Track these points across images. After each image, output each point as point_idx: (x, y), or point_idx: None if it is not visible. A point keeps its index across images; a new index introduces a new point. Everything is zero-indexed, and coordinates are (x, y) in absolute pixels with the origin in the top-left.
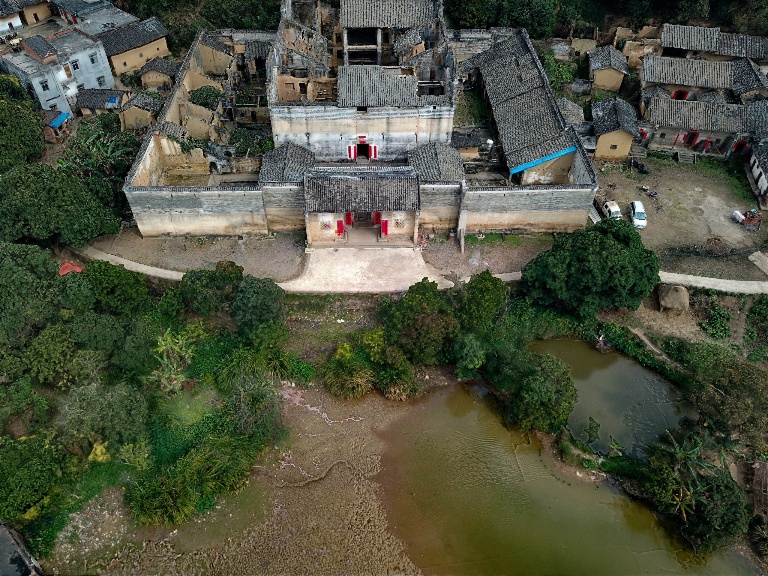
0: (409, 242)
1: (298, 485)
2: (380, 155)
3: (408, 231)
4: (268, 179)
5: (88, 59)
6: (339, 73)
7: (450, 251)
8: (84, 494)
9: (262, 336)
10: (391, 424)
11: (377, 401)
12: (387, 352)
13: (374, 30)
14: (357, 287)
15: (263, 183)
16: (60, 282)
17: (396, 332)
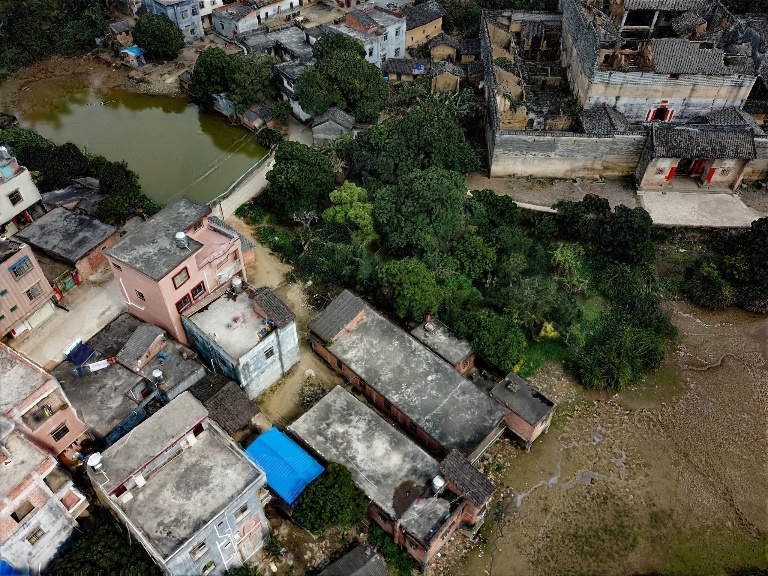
0: (728, 189)
1: (701, 369)
2: (674, 119)
3: (729, 179)
4: (598, 132)
5: (394, 32)
6: (653, 45)
7: (765, 198)
8: (532, 364)
9: (643, 253)
10: (759, 330)
11: (739, 312)
12: (756, 270)
13: (639, 14)
14: (697, 222)
15: (614, 132)
16: (462, 204)
17: (758, 255)
